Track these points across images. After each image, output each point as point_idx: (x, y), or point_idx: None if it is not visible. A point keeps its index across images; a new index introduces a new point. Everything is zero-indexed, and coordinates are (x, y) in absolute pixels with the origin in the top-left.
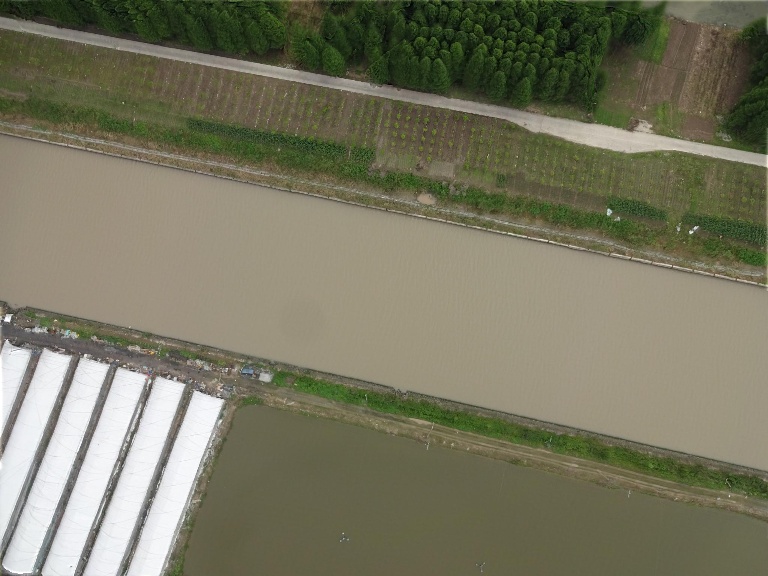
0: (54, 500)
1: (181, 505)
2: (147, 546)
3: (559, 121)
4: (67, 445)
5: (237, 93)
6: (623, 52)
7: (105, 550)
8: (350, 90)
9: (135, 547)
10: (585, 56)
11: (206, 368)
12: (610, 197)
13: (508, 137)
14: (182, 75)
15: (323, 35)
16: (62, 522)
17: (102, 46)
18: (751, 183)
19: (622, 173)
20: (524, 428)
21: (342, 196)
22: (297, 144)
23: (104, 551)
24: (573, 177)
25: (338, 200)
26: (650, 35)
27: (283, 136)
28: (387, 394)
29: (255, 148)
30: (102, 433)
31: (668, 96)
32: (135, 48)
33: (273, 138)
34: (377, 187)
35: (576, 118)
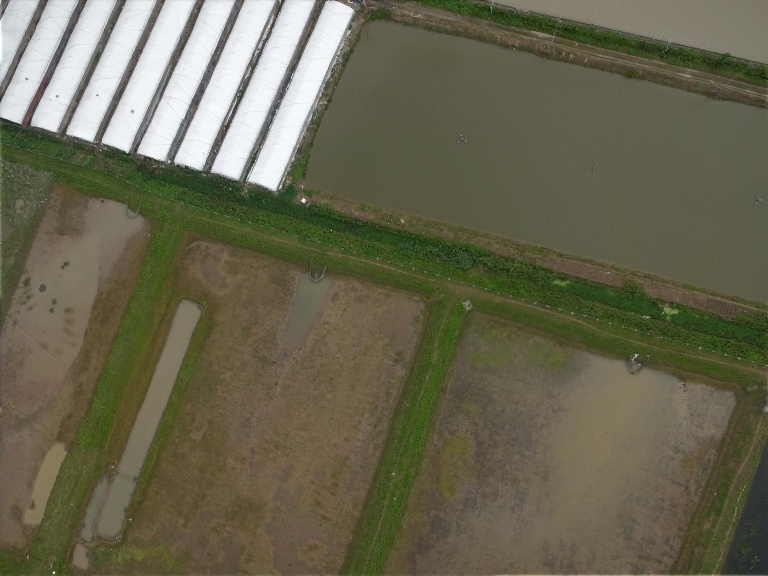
0: (189, 94)
1: (310, 101)
2: (277, 134)
3: None
4: (204, 44)
5: None
6: None
7: (238, 135)
8: None
9: (264, 140)
10: None
11: None
12: None
13: None
14: None
15: None
16: (196, 115)
17: None
18: None
19: None
20: (641, 41)
21: None
22: None
23: (237, 137)
24: None
25: None
26: None
27: None
28: (510, 10)
29: None
30: (238, 34)
31: None
32: None
33: None
34: None
35: None
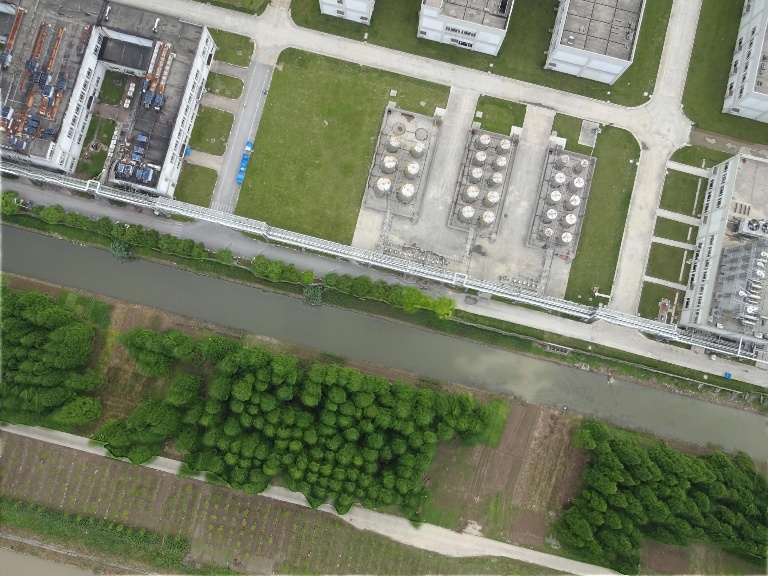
0: None
1: None
2: None
3: (386, 518)
4: None
5: (43, 467)
6: (458, 440)
7: None
8: (167, 470)
9: None
10: (406, 479)
11: None
12: None
13: (332, 533)
14: None
15: (144, 397)
16: None
17: None
18: None
19: None
20: None
21: None
22: (105, 532)
23: None
24: None
25: None
26: (485, 426)
27: (90, 522)
28: None
29: (60, 530)
30: None
31: (503, 486)
32: None
33: (78, 524)
34: None
35: (404, 515)
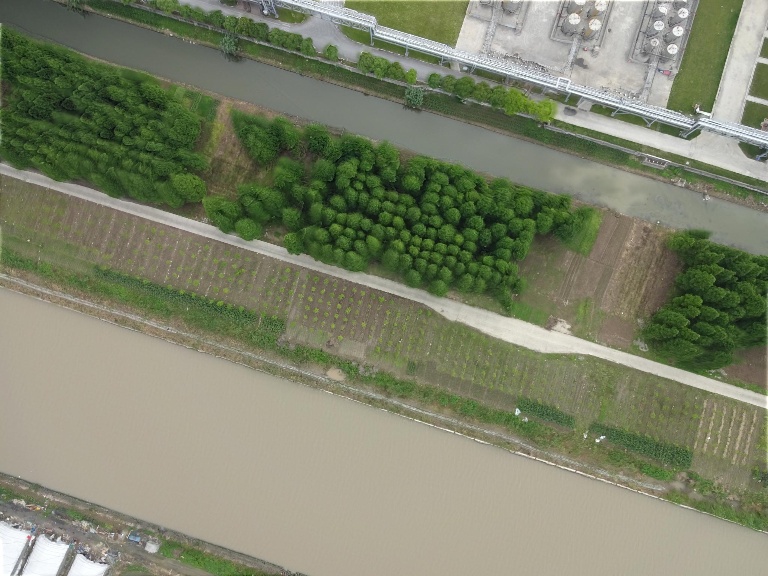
0: None
1: None
2: None
3: (477, 311)
4: None
5: (149, 244)
6: (551, 243)
7: None
8: (266, 254)
9: None
10: (504, 261)
11: (92, 531)
12: (520, 397)
13: (423, 322)
14: (93, 217)
15: (246, 187)
16: None
17: (11, 176)
18: (662, 399)
19: (535, 373)
20: None
21: (249, 363)
22: (206, 307)
23: None
24: (485, 372)
25: (245, 365)
26: (579, 230)
27: (192, 297)
28: (275, 575)
29: (163, 304)
30: None
31: (592, 292)
32: (46, 182)
33: (181, 298)
34: (285, 358)
35: (495, 310)
